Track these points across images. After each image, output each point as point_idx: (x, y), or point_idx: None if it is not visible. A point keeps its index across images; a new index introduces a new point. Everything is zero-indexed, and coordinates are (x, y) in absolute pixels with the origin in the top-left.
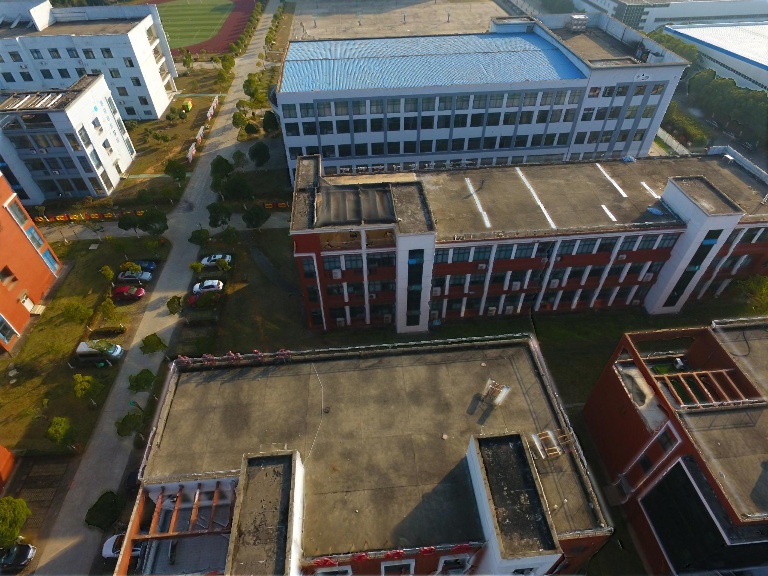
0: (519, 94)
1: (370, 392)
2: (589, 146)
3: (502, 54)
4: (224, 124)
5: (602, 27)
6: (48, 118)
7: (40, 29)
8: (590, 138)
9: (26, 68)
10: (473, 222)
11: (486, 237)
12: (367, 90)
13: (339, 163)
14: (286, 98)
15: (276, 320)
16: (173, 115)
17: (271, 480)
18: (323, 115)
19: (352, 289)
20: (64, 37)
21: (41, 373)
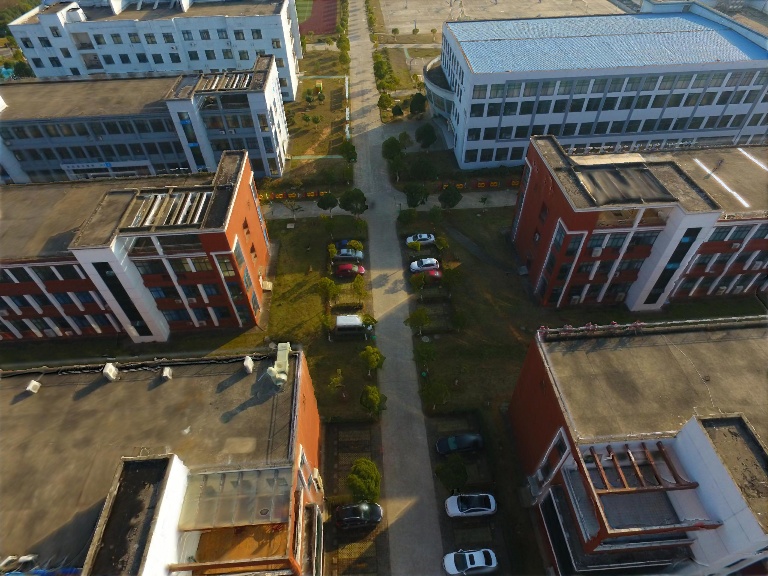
0: (708, 75)
1: (738, 362)
2: (761, 128)
3: (676, 34)
4: (361, 106)
5: (756, 7)
6: (246, 99)
7: (185, 10)
8: (764, 120)
9: (176, 49)
10: (729, 202)
11: (754, 216)
12: (561, 71)
13: (512, 144)
14: (480, 79)
15: (505, 298)
16: (312, 97)
17: (733, 440)
18: (511, 96)
19: (598, 267)
20: (217, 18)
21: (303, 346)
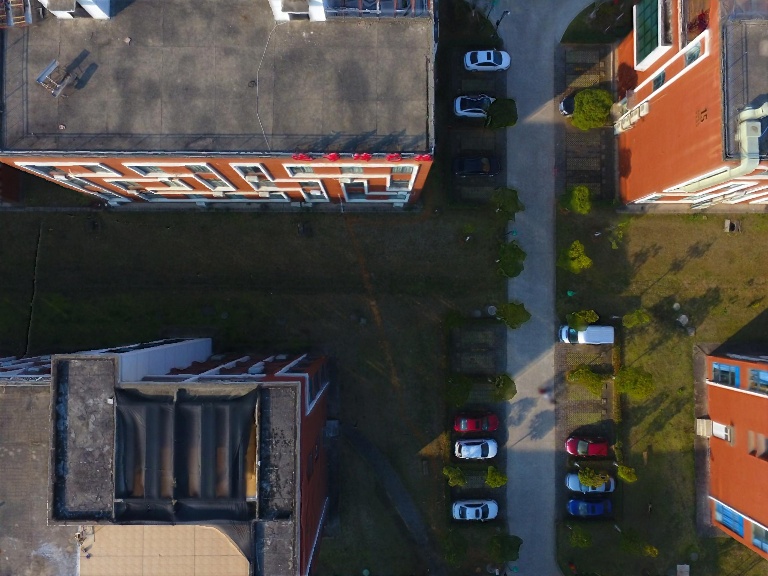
0: None
1: (202, 102)
2: None
3: None
4: None
5: None
6: None
7: None
8: None
9: None
10: (2, 430)
11: None
12: None
13: None
14: None
15: (372, 376)
16: None
17: None
18: None
19: None
20: None
21: (648, 312)
